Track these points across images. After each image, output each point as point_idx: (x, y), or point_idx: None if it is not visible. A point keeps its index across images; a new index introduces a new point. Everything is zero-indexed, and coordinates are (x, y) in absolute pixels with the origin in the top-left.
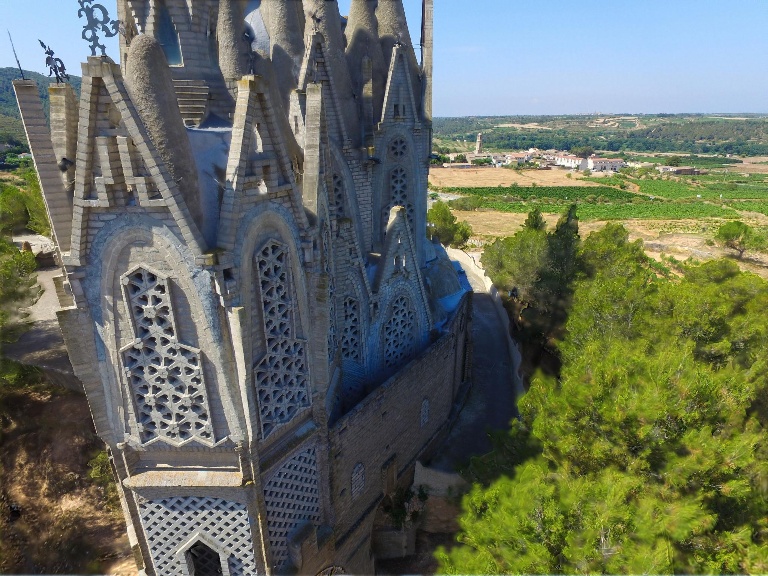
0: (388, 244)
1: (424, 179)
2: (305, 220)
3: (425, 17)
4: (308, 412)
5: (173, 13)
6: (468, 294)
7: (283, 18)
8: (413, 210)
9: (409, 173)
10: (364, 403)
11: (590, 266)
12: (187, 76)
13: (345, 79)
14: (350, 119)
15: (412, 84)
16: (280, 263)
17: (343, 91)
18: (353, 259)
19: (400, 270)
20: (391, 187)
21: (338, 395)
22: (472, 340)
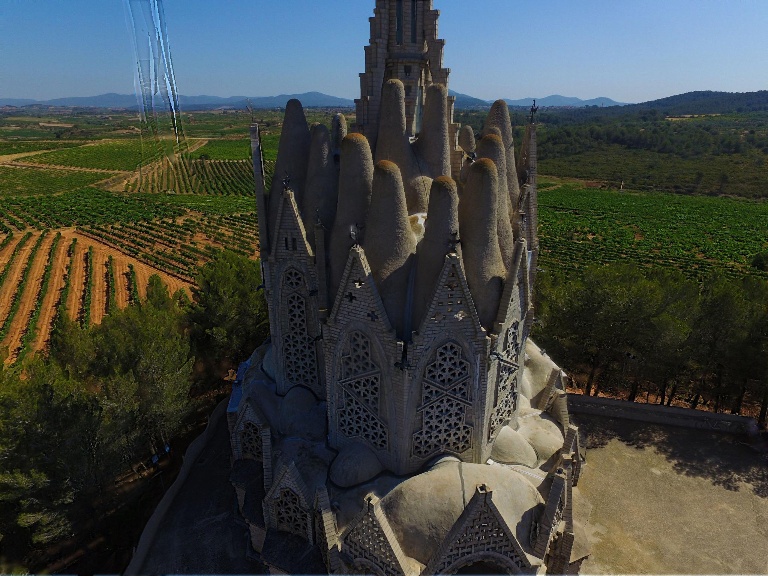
0: None
1: None
2: None
3: None
4: None
5: None
6: None
7: None
8: None
9: None
10: None
11: None
12: None
13: None
14: None
15: None
16: None
17: None
18: None
19: None
20: None
21: None
22: None
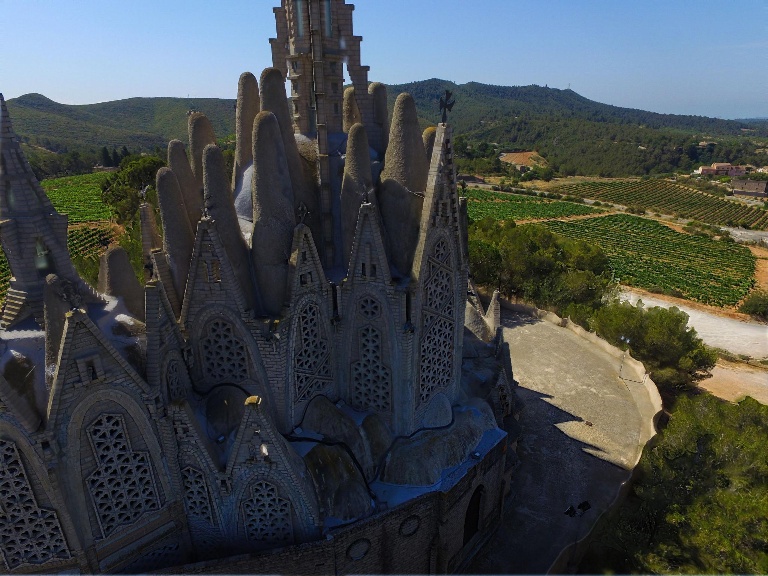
0: (238, 431)
1: (403, 345)
2: (28, 427)
3: (431, 161)
4: (75, 561)
5: (4, 247)
6: (439, 494)
7: (206, 197)
8: (388, 374)
9: (384, 335)
10: (149, 575)
11: (690, 548)
12: (19, 287)
13: (277, 245)
14: (277, 284)
15: (408, 235)
16: (11, 453)
17: (272, 257)
18: (188, 437)
19: (257, 458)
20: (361, 344)
21: (176, 545)
22: (445, 547)
